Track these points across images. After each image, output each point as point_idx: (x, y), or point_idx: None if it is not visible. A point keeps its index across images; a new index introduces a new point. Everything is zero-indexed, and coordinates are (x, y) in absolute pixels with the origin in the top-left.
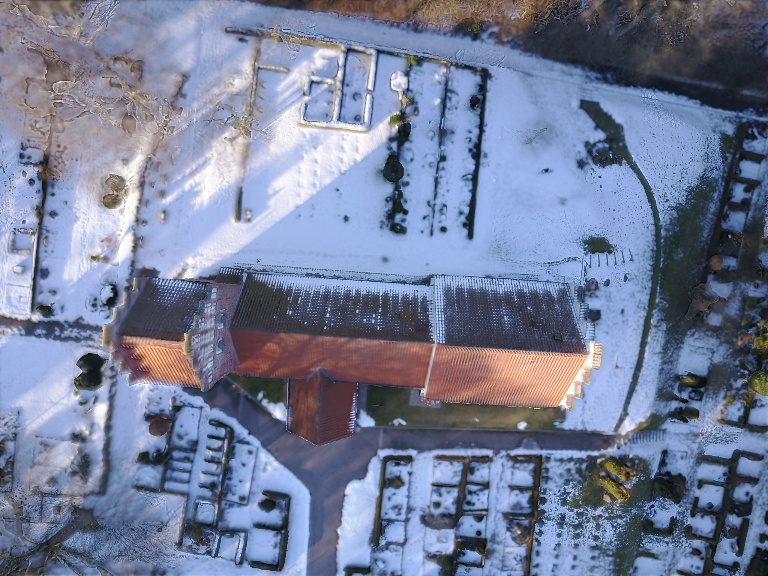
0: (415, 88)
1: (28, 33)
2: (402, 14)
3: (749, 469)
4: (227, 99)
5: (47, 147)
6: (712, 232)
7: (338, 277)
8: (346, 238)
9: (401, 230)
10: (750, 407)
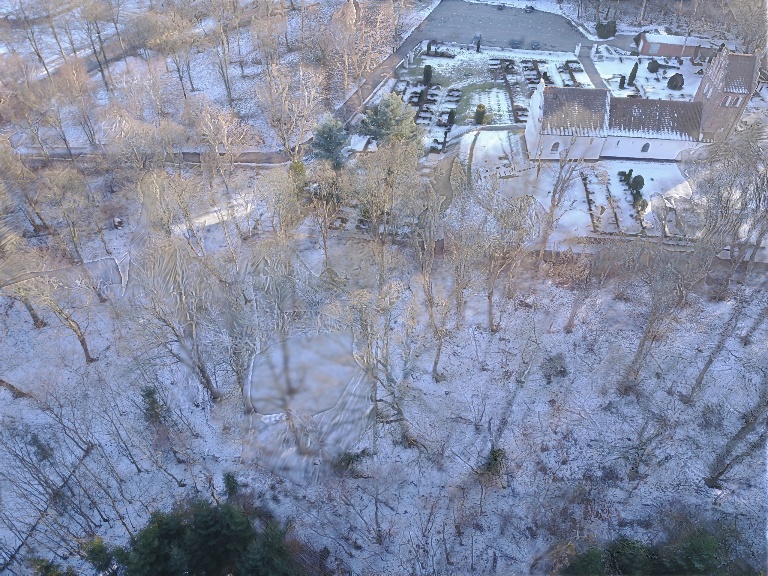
0: None
1: None
2: None
3: None
4: None
5: None
6: None
7: (647, 162)
8: None
9: None
10: None
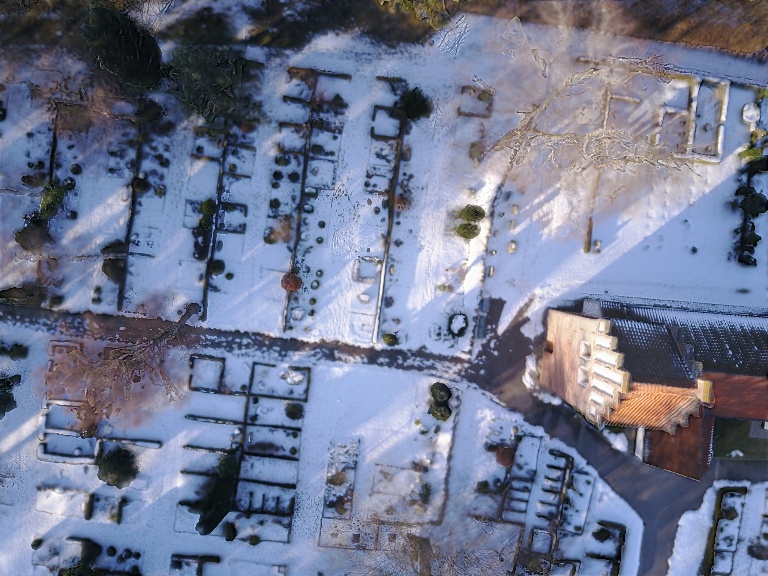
0: (765, 119)
1: (376, 60)
2: (757, 45)
3: None
4: (576, 128)
5: (395, 175)
6: None
7: (686, 308)
8: (694, 269)
9: (754, 262)
10: None
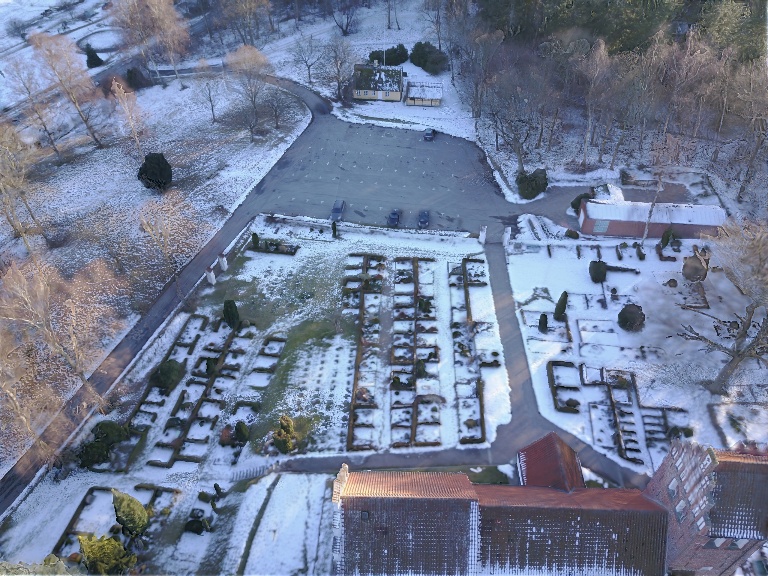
0: None
1: None
2: None
3: (161, 454)
4: None
5: None
6: None
7: None
8: None
9: None
10: (149, 504)
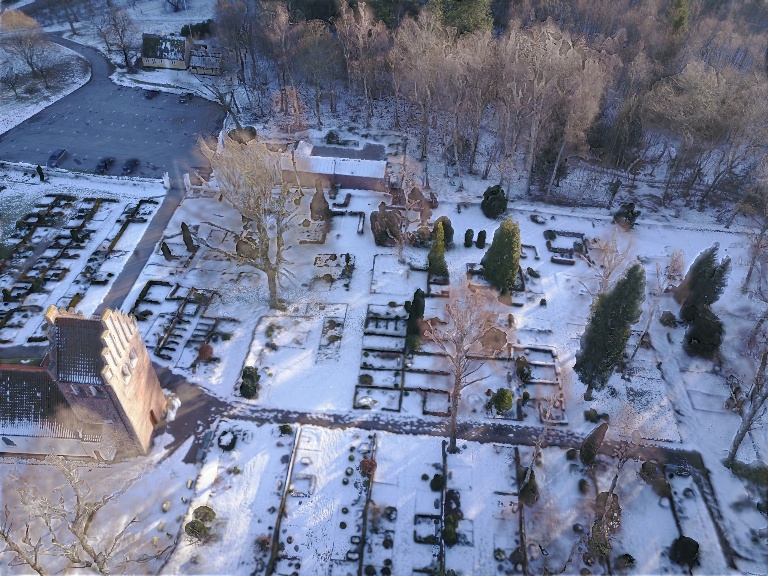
0: None
1: None
2: None
3: None
4: None
5: None
6: None
7: (24, 458)
8: (3, 492)
9: None
10: None
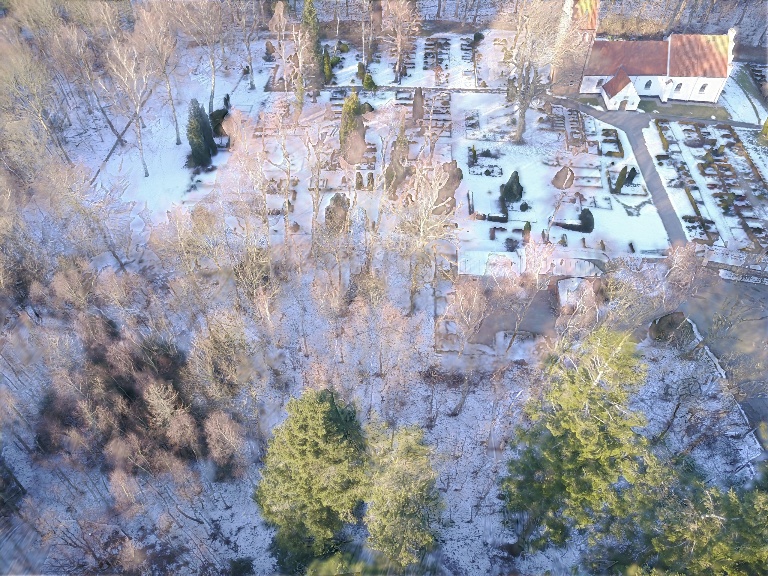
0: None
1: None
2: (600, 30)
3: None
4: None
5: None
6: (757, 86)
7: None
8: None
9: None
10: None
